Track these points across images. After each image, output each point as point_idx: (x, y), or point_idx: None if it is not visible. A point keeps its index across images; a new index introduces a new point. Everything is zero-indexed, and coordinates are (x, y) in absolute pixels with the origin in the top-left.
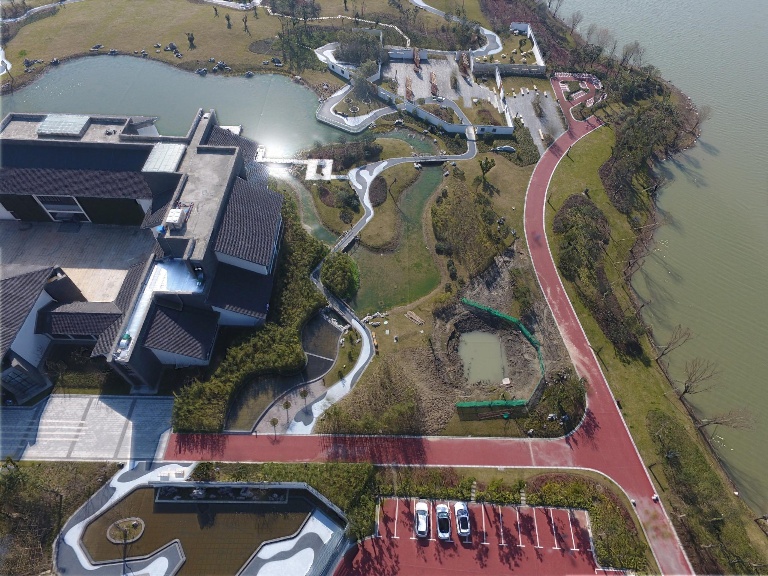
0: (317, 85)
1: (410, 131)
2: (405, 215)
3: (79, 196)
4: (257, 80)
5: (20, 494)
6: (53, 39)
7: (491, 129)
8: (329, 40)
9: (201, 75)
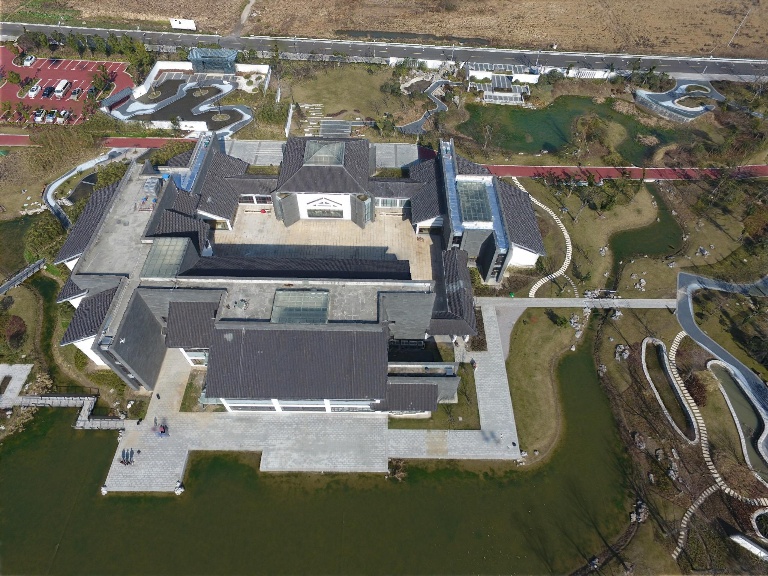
0: None
1: None
2: None
3: None
4: None
5: None
6: None
7: None
8: None
9: None
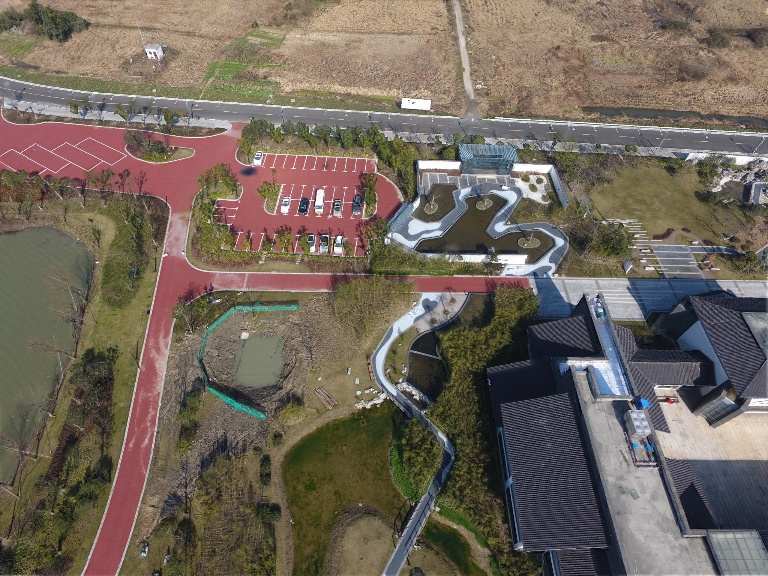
0: None
1: None
2: None
3: None
4: None
5: None
6: None
7: None
8: None
9: None
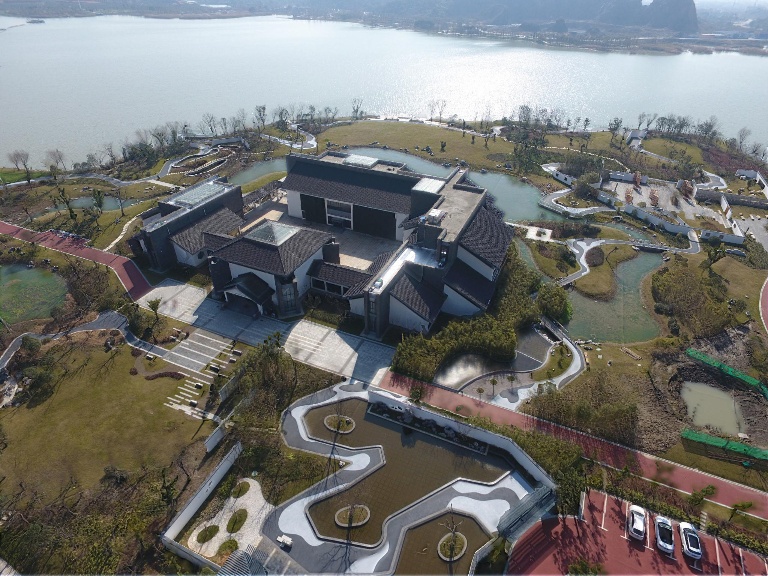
0: (541, 184)
1: (628, 225)
2: (621, 280)
3: (356, 204)
4: (490, 176)
5: (271, 367)
6: (347, 136)
7: (718, 235)
8: (554, 161)
9: (446, 167)
